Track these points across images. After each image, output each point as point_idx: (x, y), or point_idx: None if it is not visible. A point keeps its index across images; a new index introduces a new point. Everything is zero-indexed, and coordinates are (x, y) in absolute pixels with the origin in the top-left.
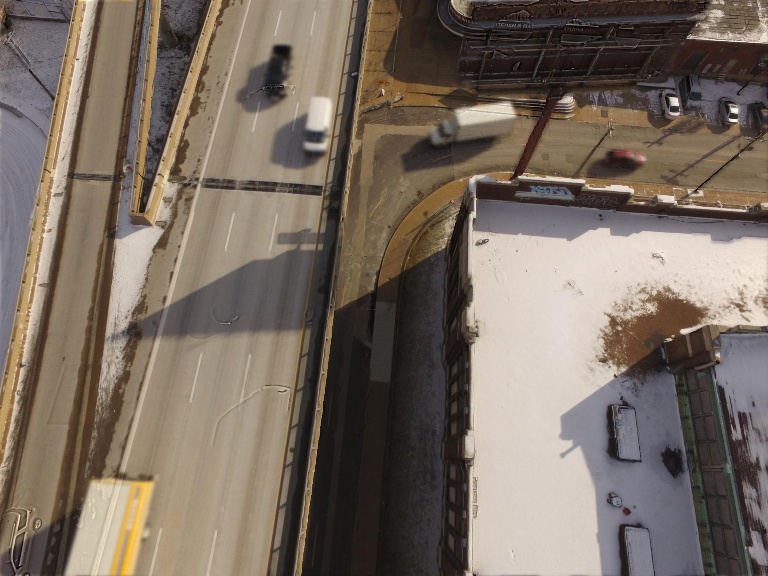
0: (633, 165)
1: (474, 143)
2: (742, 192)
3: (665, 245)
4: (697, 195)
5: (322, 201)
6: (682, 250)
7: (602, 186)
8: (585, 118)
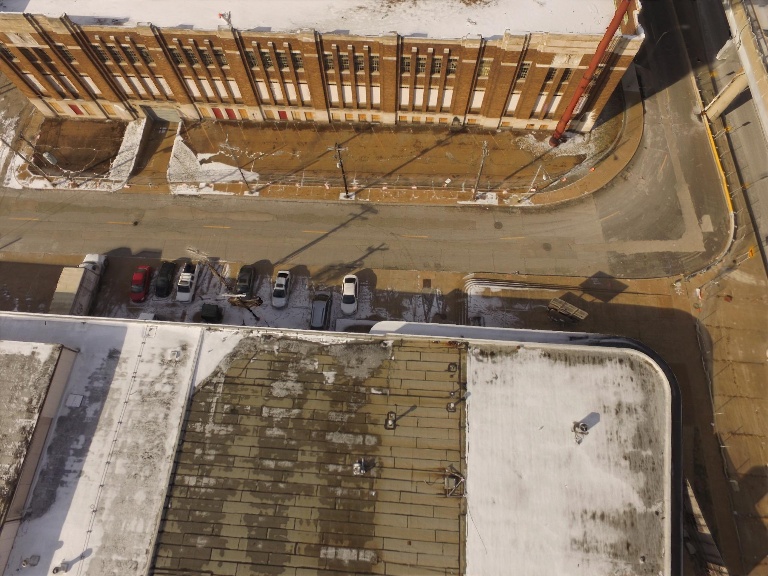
0: (405, 222)
1: (577, 235)
2: (299, 200)
3: (465, 30)
4: (347, 194)
5: (760, 25)
6: (453, 27)
7: (441, 198)
8: (451, 277)
